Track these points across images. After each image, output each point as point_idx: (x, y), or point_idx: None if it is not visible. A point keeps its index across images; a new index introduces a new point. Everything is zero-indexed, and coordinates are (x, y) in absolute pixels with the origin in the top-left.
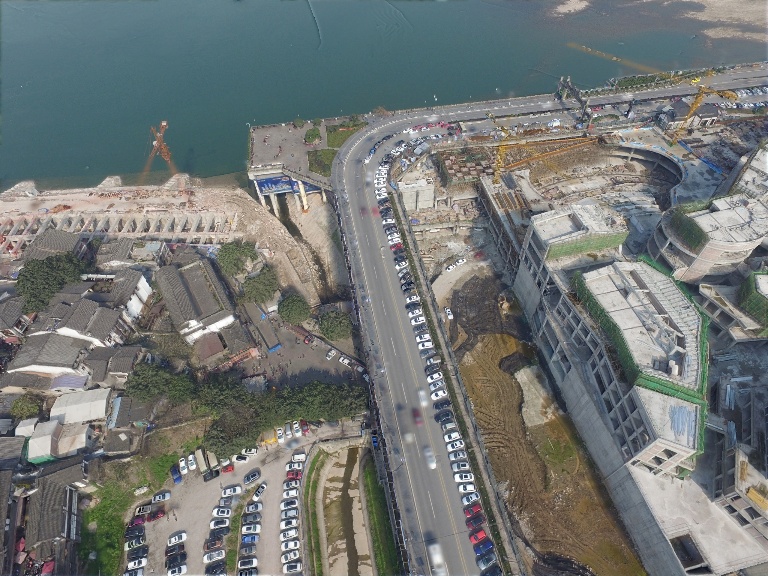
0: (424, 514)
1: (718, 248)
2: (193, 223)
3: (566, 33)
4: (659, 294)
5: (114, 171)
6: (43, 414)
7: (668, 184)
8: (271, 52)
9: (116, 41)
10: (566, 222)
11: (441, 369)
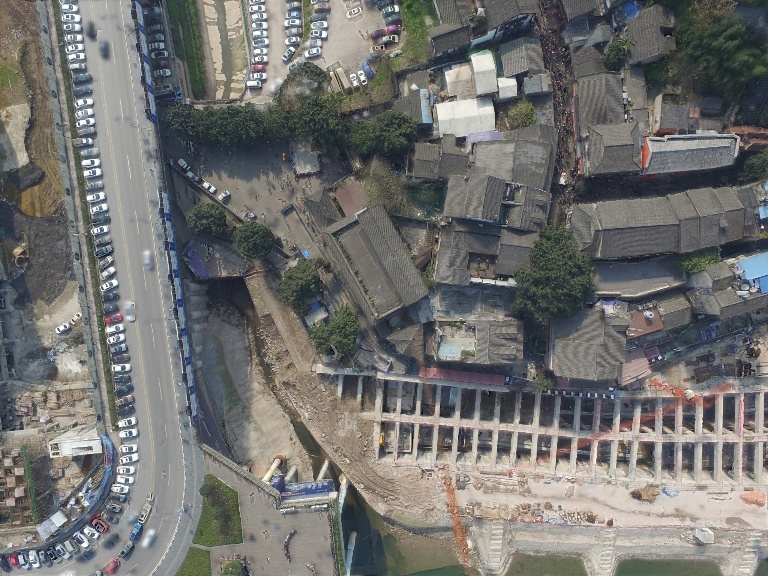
0: None
1: None
2: (437, 443)
3: None
4: None
5: None
6: (505, 114)
7: None
8: None
9: None
10: None
11: None
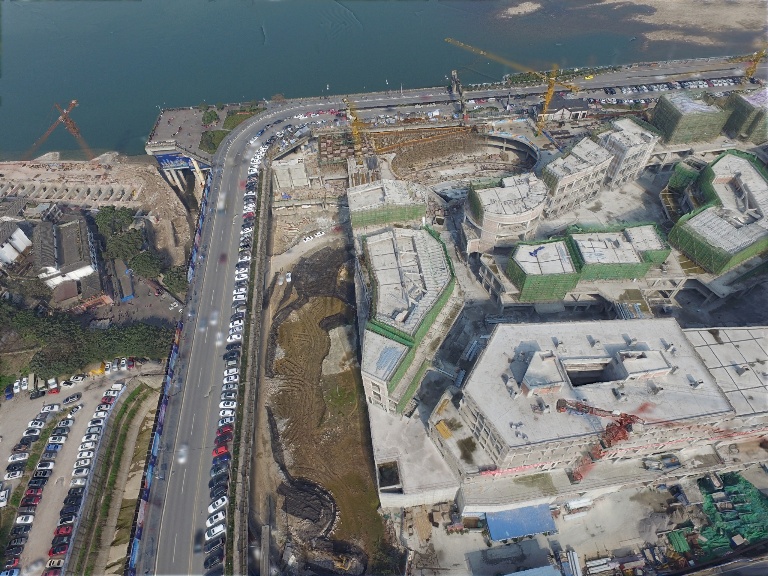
0: (183, 431)
1: (493, 220)
2: (102, 193)
3: (508, 34)
4: (424, 257)
5: (56, 148)
6: None
7: None
8: (216, 46)
9: (95, 35)
10: (378, 195)
11: (245, 318)
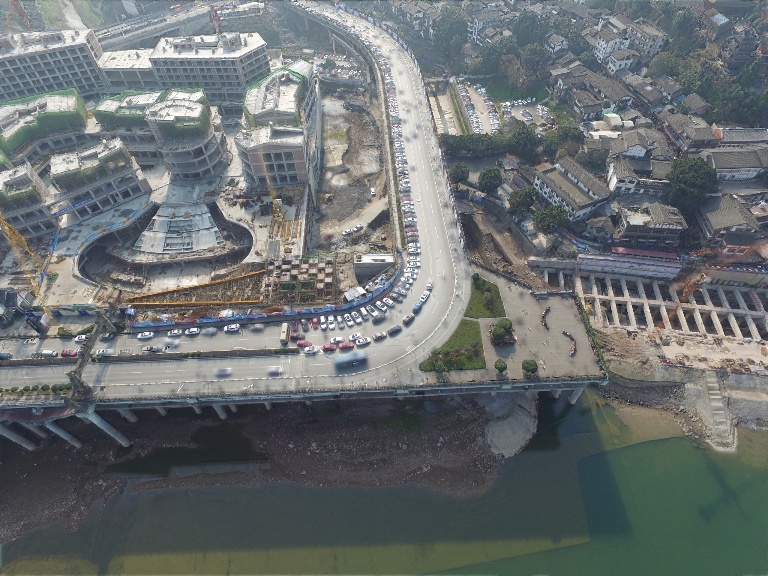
0: None
1: None
2: None
3: None
4: None
5: None
6: None
7: (92, 274)
8: None
9: None
10: None
11: None
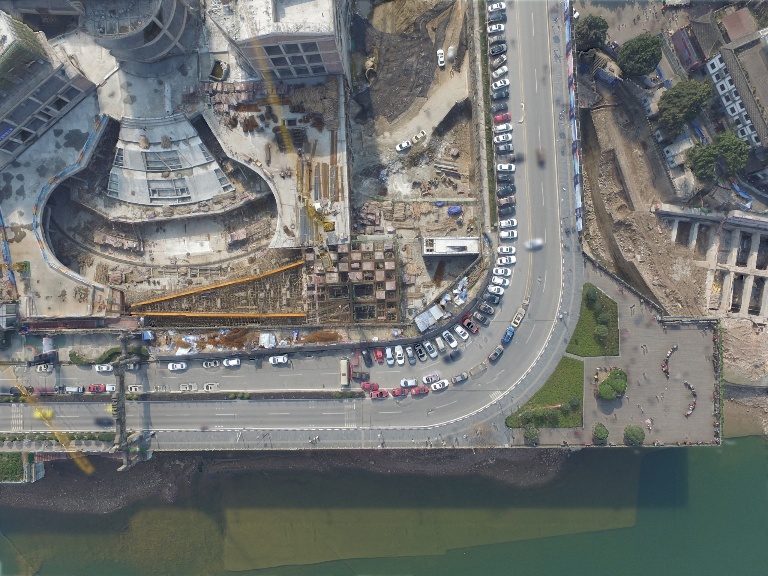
0: None
1: None
2: None
3: None
4: None
5: None
6: None
7: (67, 229)
8: None
9: None
10: None
11: None
